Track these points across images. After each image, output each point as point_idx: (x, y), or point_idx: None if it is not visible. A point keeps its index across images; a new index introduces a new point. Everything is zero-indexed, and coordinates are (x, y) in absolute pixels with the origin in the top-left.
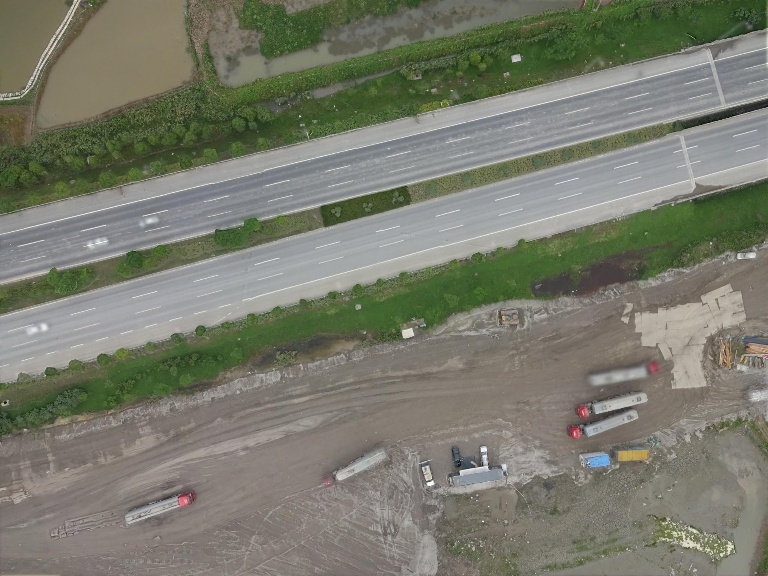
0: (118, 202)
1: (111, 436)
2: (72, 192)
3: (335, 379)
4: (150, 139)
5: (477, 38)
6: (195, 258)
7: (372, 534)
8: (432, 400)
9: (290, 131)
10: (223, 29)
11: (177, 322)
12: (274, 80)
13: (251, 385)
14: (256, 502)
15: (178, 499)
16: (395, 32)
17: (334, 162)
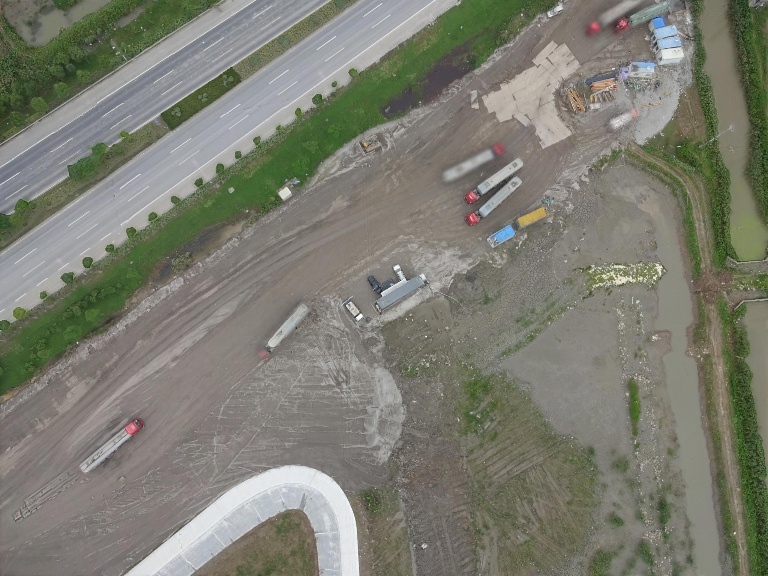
0: None
1: (41, 400)
2: None
3: (235, 261)
4: None
5: None
6: (61, 204)
7: (326, 389)
8: (332, 244)
9: None
10: (15, 1)
11: (66, 269)
12: (77, 24)
13: (158, 299)
14: (204, 405)
15: (125, 428)
16: None
17: (158, 72)
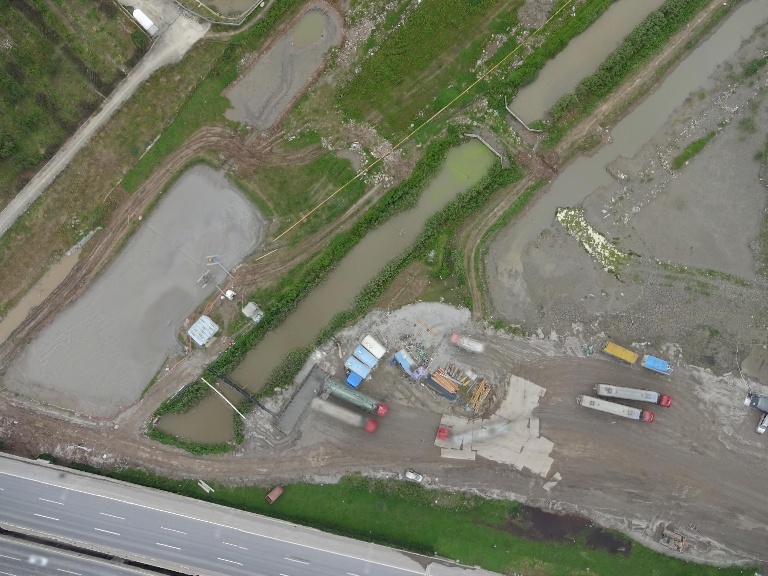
0: None
1: None
2: None
3: None
4: None
5: None
6: None
7: None
8: None
9: None
10: None
11: None
12: None
13: None
14: None
15: None
16: None
17: None
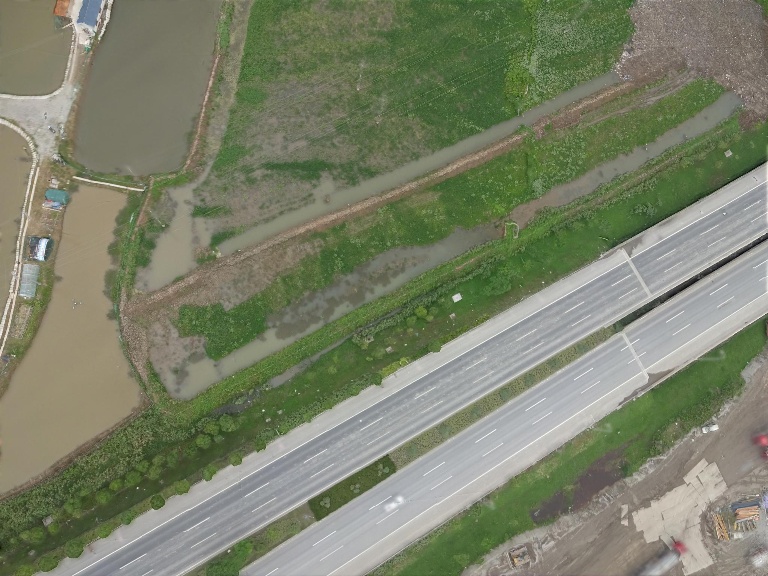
0: (89, 562)
1: None
2: (34, 568)
3: None
4: (112, 486)
5: (417, 290)
6: None
7: None
8: None
9: (260, 439)
10: (163, 342)
11: None
12: (229, 383)
13: None
14: None
15: None
16: (337, 301)
17: (310, 450)
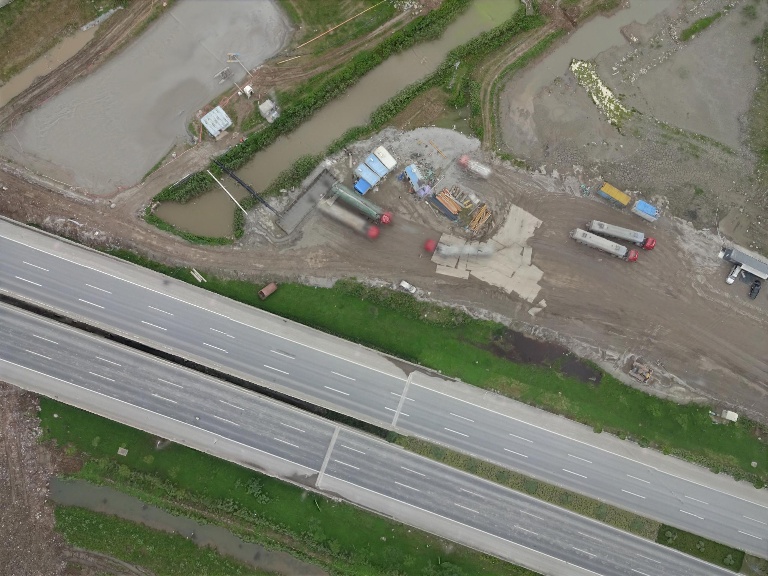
0: None
1: None
2: None
3: None
4: None
5: None
6: None
7: None
8: (744, 348)
9: None
10: None
11: None
12: None
13: None
14: None
15: None
16: None
17: None
